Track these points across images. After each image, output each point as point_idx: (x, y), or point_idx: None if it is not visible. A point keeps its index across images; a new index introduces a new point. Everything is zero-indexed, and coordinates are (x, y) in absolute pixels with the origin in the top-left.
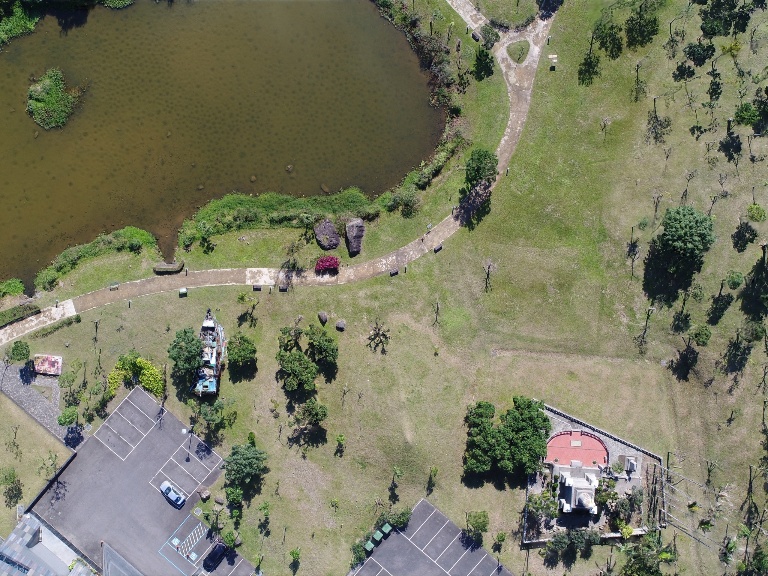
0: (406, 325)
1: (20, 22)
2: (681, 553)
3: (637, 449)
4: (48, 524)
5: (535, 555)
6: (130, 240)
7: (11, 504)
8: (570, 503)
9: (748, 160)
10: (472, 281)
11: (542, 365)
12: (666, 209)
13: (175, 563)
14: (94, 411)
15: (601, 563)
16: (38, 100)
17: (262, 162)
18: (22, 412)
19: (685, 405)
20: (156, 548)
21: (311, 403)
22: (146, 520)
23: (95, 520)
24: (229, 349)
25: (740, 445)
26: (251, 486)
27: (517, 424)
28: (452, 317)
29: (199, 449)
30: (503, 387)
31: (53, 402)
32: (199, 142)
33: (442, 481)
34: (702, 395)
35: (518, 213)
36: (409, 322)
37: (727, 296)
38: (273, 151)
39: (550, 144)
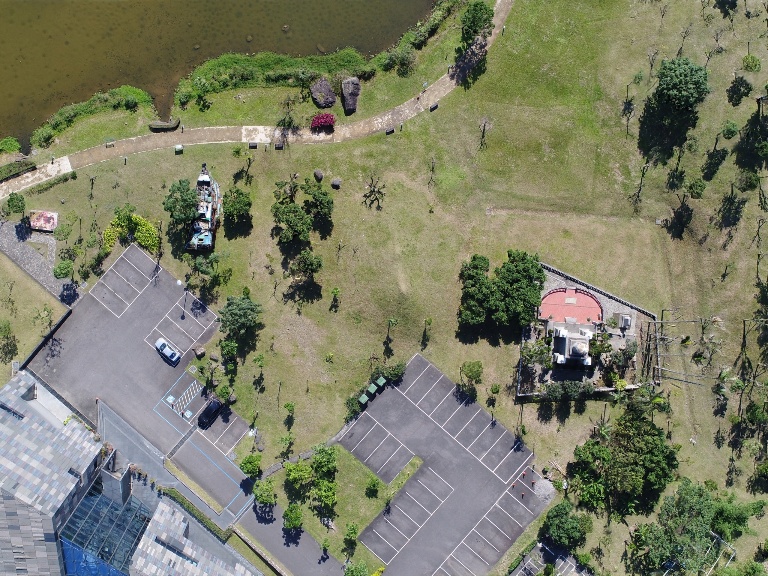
0: (401, 183)
1: None
2: (675, 411)
3: (631, 307)
4: (43, 381)
5: (529, 410)
6: (126, 98)
7: (6, 360)
8: (564, 354)
9: (743, 16)
10: (467, 140)
11: (537, 223)
12: (661, 62)
13: (170, 421)
14: (89, 268)
15: (595, 418)
16: None
17: (258, 22)
18: (17, 268)
19: (679, 263)
20: (151, 406)
21: (306, 253)
22: (141, 378)
23: (90, 377)
24: (224, 202)
25: (734, 300)
26: (246, 343)
27: (512, 276)
28: (447, 175)
29: (194, 307)
30: (498, 245)
31: (48, 259)
32: (195, 2)
33: (437, 335)
34: (696, 253)
35: (514, 72)
36: (404, 180)
37: (722, 151)
38: (269, 11)
39: (546, 3)
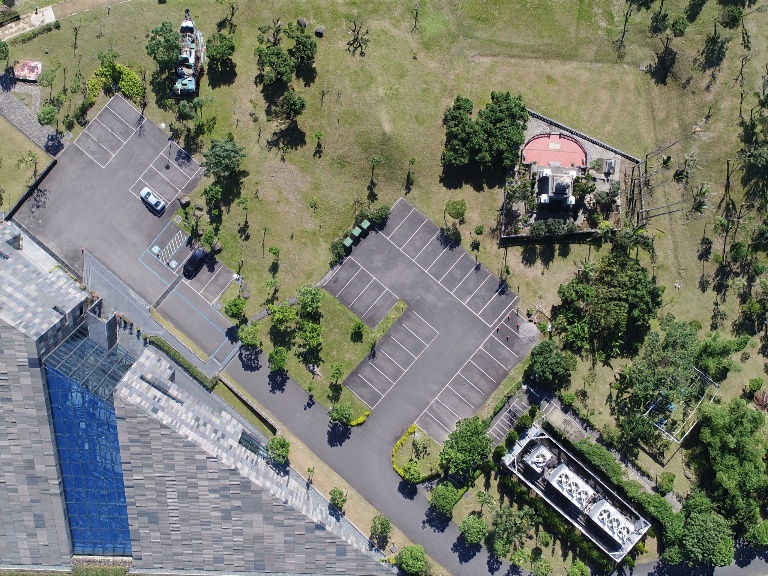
0: (385, 30)
1: None
2: (659, 256)
3: (615, 152)
4: (29, 232)
5: (513, 253)
6: None
7: None
8: (547, 193)
9: None
10: None
11: (521, 70)
12: None
13: (155, 271)
14: (74, 118)
15: (579, 262)
16: None
17: None
18: (2, 118)
19: (663, 109)
20: (136, 256)
21: (289, 94)
22: (126, 228)
23: (75, 228)
24: (208, 47)
25: (717, 140)
26: (230, 191)
27: (495, 116)
28: (431, 23)
29: (179, 156)
30: (482, 92)
31: (33, 109)
32: None
33: (420, 179)
34: (680, 97)
35: None
36: (388, 28)
37: None
38: None
39: None
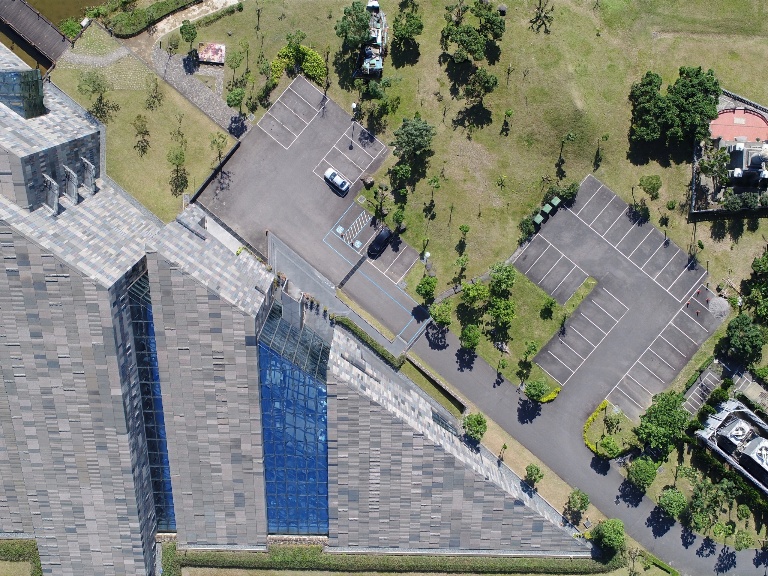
0: (567, 8)
1: None
2: None
3: None
4: (213, 214)
5: (702, 228)
6: None
7: (177, 193)
8: (741, 167)
9: None
10: None
11: (704, 45)
12: None
13: (339, 251)
14: (257, 100)
15: (767, 236)
16: None
17: None
18: (186, 101)
19: None
20: (320, 236)
21: (482, 71)
22: (310, 209)
23: (259, 209)
24: (396, 26)
25: None
26: (416, 170)
27: (686, 91)
28: None
29: (362, 137)
30: (665, 68)
31: (216, 92)
32: None
33: (609, 156)
34: None
35: None
36: (570, 5)
37: None
38: None
39: None
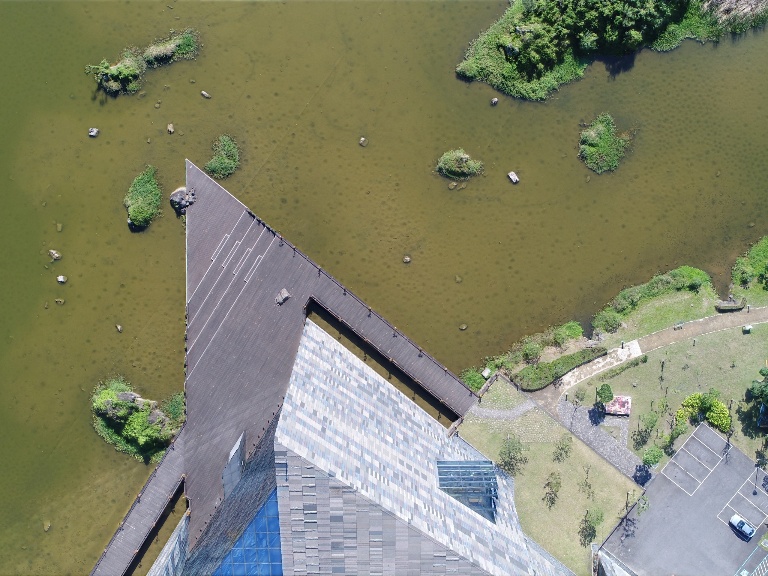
0: None
1: (570, 69)
2: None
3: None
4: (618, 561)
5: None
6: (690, 280)
7: (586, 543)
8: None
9: None
10: None
11: None
12: None
13: None
14: (662, 449)
15: None
16: (591, 145)
17: None
18: (593, 452)
19: None
20: None
21: None
22: (715, 553)
23: (665, 555)
24: None
25: None
26: None
27: None
28: None
29: (765, 482)
30: None
31: (621, 441)
32: (748, 180)
33: None
34: None
35: None
36: None
37: None
38: None
39: None
